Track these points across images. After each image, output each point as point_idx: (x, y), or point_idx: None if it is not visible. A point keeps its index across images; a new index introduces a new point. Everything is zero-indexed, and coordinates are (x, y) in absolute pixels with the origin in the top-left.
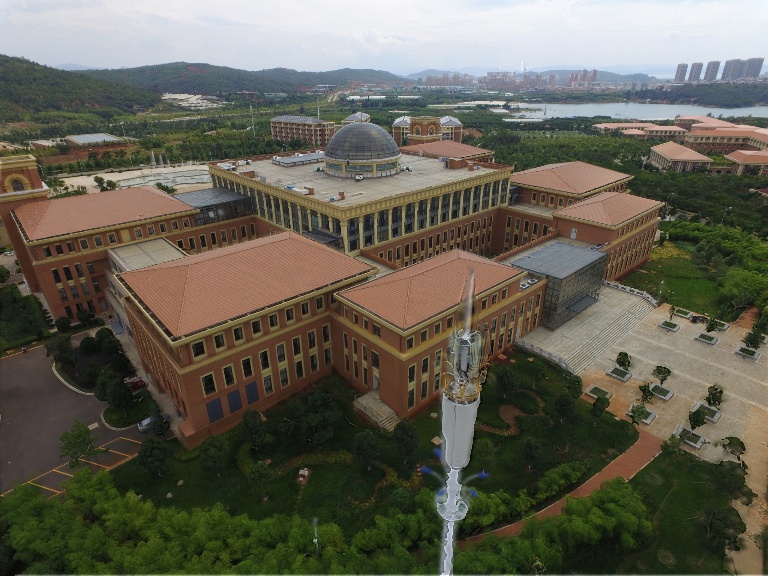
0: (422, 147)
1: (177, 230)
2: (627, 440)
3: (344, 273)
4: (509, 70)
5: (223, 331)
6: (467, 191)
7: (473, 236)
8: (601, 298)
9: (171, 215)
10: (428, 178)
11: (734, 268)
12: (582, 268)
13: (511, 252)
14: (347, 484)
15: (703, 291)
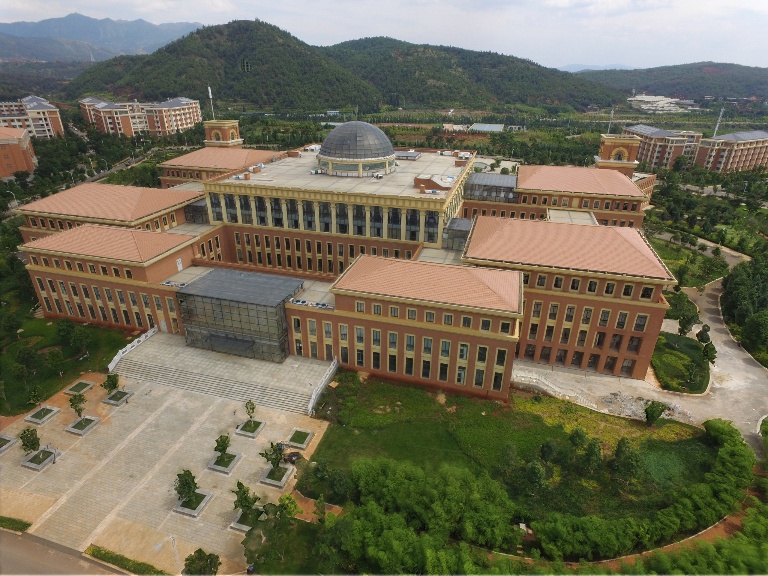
0: (542, 169)
1: None
2: (2, 409)
3: (114, 216)
4: None
5: (43, 218)
6: (362, 208)
7: None
8: (290, 365)
9: (226, 170)
10: (355, 186)
11: (589, 512)
12: (215, 298)
13: (260, 268)
14: None
15: (412, 463)
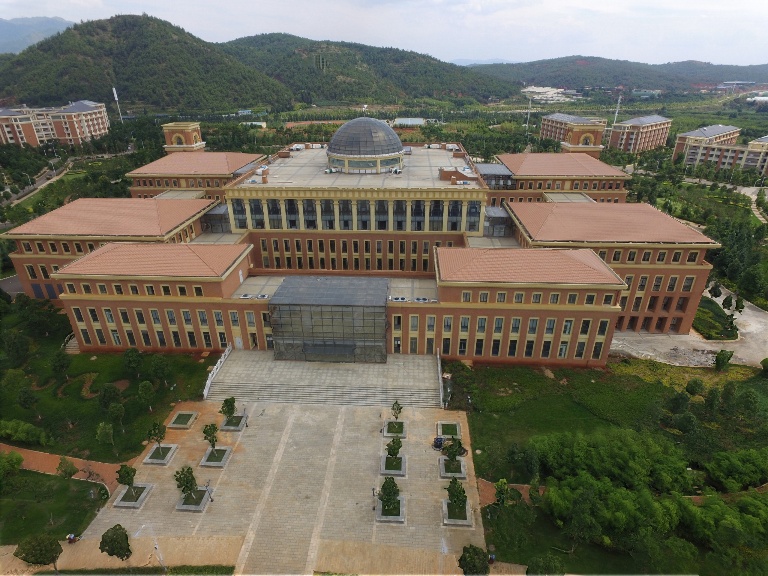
0: (528, 156)
1: (218, 187)
2: (107, 456)
3: (138, 232)
4: (306, 65)
5: (41, 241)
6: (402, 203)
7: (417, 257)
8: (395, 364)
9: (211, 175)
10: (383, 182)
11: (729, 448)
12: (315, 305)
13: (329, 271)
14: (2, 361)
15: None
